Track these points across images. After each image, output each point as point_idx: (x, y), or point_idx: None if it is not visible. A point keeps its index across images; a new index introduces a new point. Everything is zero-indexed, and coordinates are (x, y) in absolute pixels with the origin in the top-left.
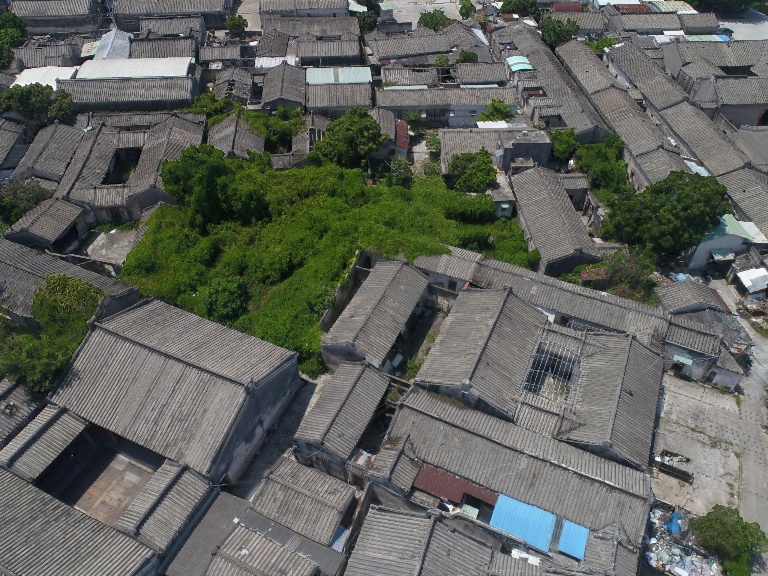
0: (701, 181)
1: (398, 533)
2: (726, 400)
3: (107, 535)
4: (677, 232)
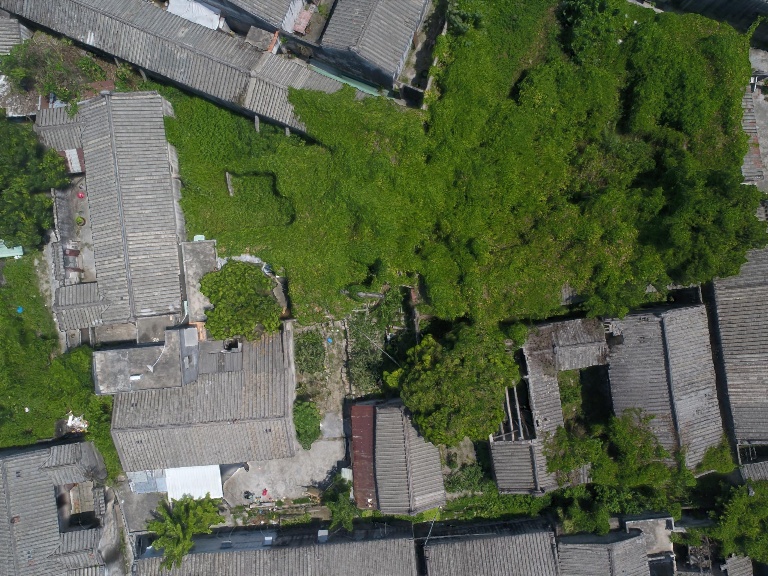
0: None
1: None
2: None
3: None
4: None
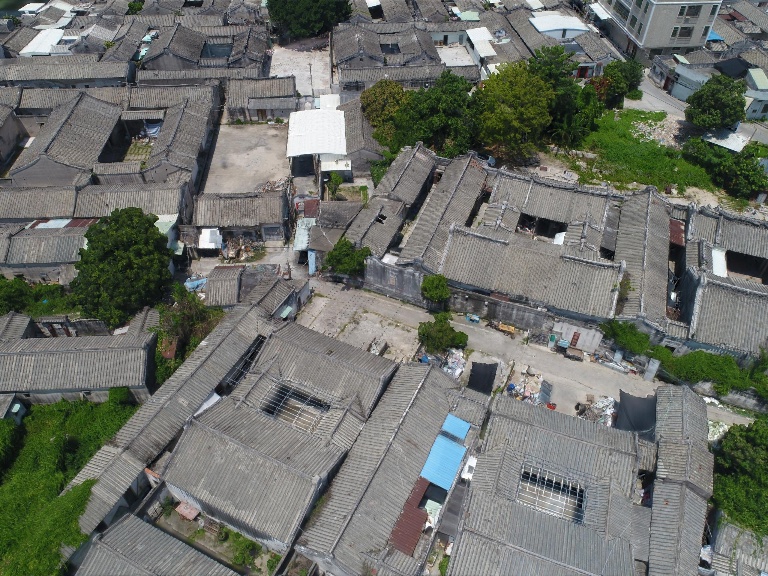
0: (121, 218)
1: (473, 567)
2: (317, 302)
3: None
4: (161, 262)
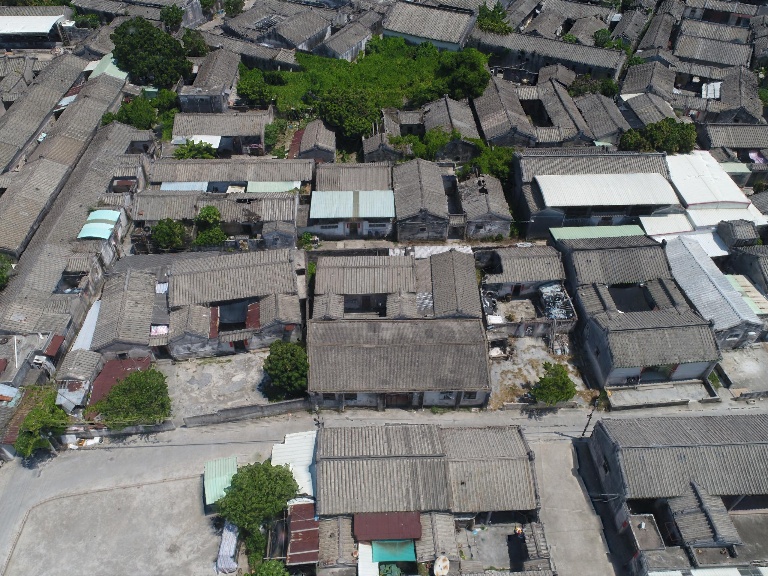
0: (131, 25)
1: None
2: None
3: (440, 2)
4: None
